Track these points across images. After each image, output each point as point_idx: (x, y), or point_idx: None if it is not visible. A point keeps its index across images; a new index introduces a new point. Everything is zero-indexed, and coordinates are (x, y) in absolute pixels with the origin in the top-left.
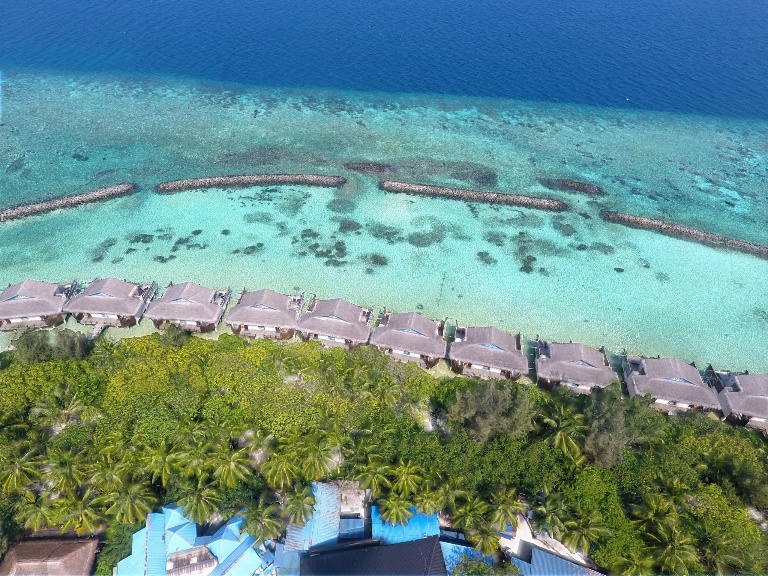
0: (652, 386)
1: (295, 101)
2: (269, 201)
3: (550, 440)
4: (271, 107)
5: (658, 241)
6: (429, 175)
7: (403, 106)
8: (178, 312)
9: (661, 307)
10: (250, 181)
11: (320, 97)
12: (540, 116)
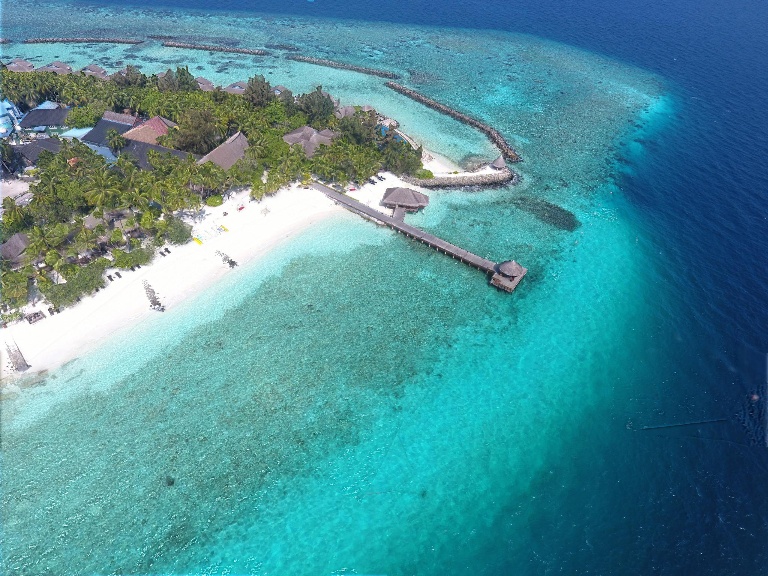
0: (226, 90)
1: (138, 11)
2: (90, 48)
3: (149, 88)
4: (118, 13)
5: (307, 66)
6: (198, 41)
7: (211, 15)
8: (10, 69)
9: (277, 83)
10: (82, 40)
11: (157, 10)
12: (300, 21)
